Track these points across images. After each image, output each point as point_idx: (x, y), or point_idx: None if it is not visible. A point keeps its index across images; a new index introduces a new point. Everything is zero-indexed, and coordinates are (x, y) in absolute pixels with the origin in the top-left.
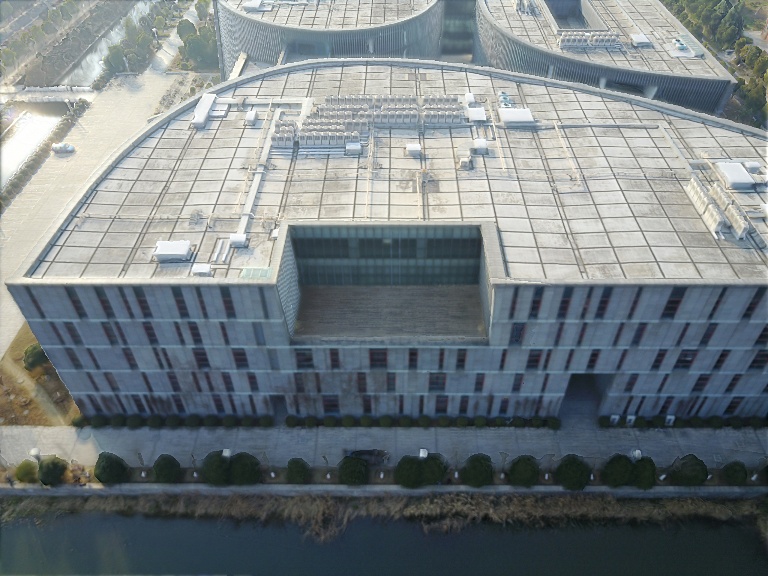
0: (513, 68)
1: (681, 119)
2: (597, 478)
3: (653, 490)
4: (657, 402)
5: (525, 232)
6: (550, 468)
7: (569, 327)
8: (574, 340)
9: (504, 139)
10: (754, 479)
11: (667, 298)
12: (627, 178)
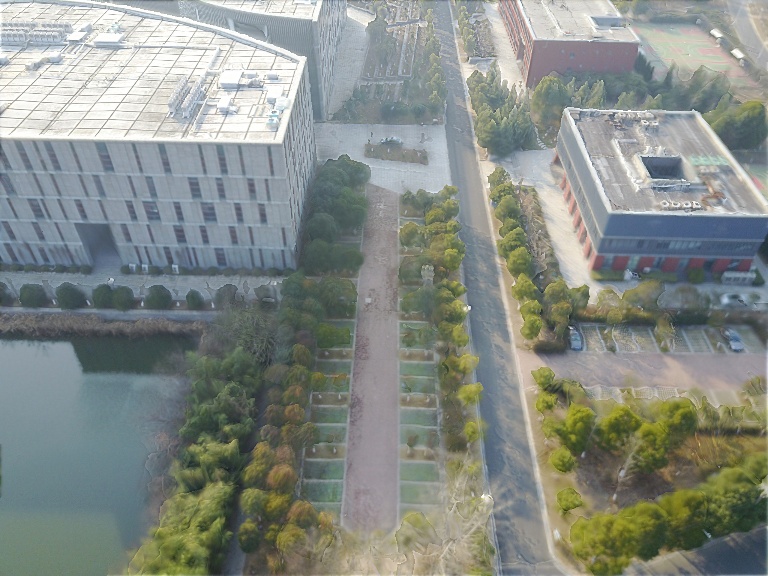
0: (183, 13)
1: (243, 44)
2: (93, 304)
3: (131, 312)
4: (158, 252)
5: (27, 110)
6: (53, 294)
7: (42, 178)
8: (53, 190)
9: (84, 54)
10: (214, 307)
11: (96, 152)
12: (147, 79)
